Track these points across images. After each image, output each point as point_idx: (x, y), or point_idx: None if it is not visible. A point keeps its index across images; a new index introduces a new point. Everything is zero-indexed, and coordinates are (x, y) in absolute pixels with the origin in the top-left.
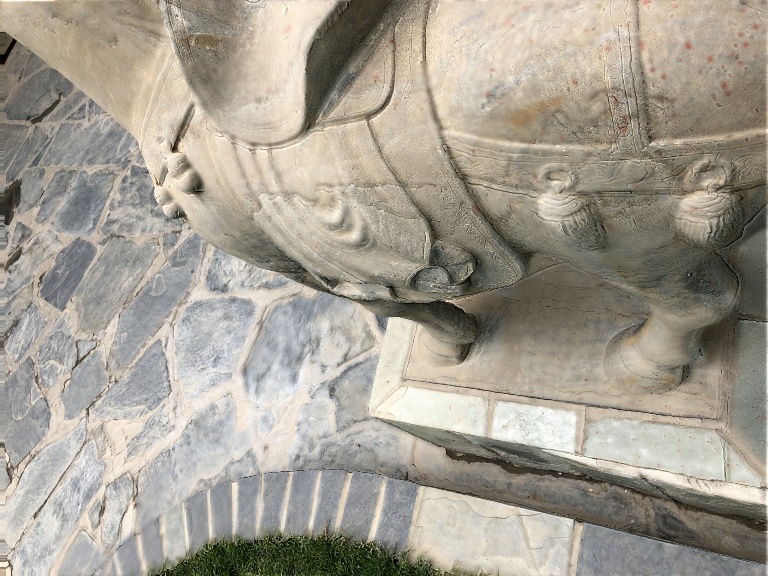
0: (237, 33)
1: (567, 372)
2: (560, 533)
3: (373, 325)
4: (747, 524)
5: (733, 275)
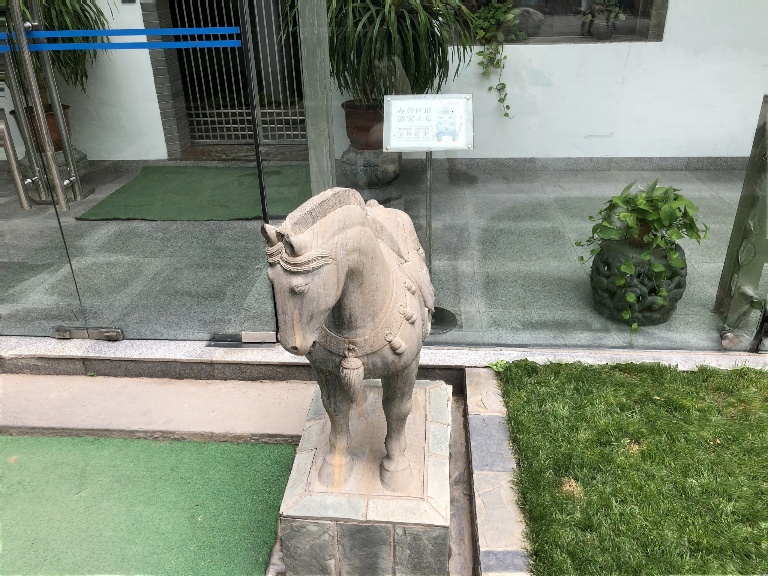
0: None
1: (411, 426)
2: (481, 478)
3: None
4: (450, 458)
5: None
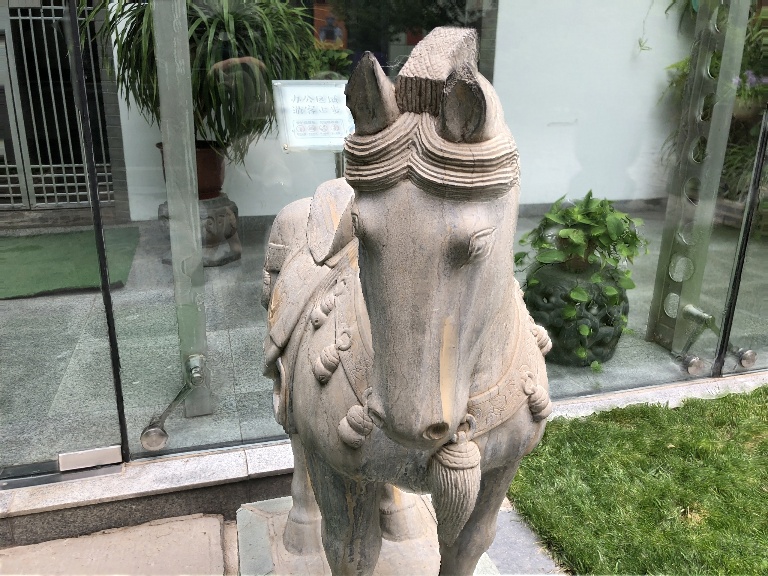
0: None
1: (432, 558)
2: None
3: None
4: None
5: None
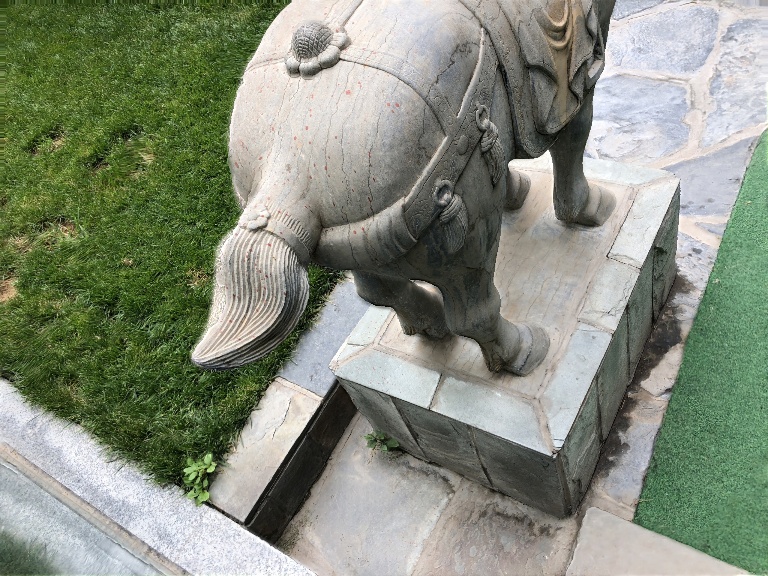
0: None
1: None
2: None
3: None
4: None
5: (366, 292)
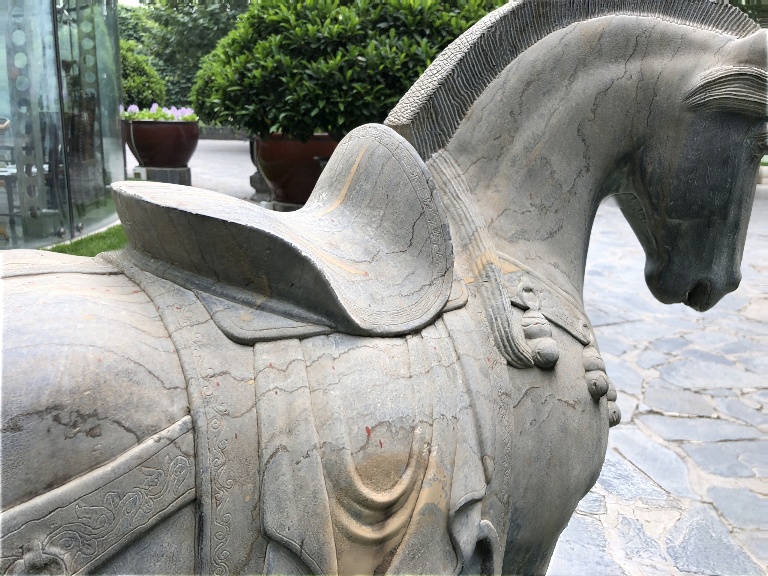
0: None
1: None
2: None
3: None
4: None
5: None
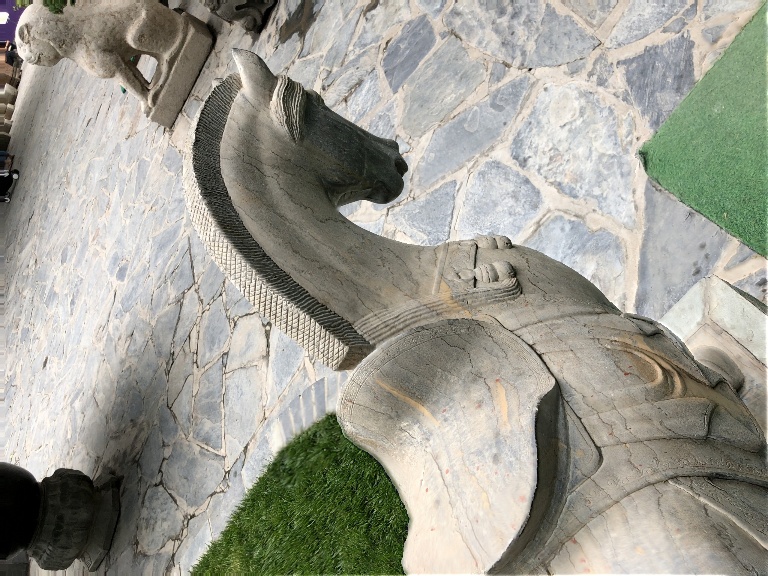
0: (393, 447)
1: None
2: None
3: (629, 301)
4: None
5: None
